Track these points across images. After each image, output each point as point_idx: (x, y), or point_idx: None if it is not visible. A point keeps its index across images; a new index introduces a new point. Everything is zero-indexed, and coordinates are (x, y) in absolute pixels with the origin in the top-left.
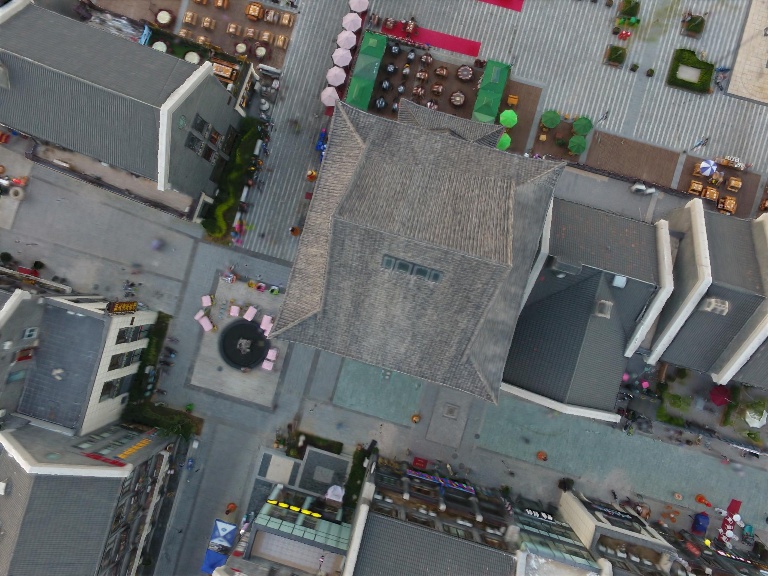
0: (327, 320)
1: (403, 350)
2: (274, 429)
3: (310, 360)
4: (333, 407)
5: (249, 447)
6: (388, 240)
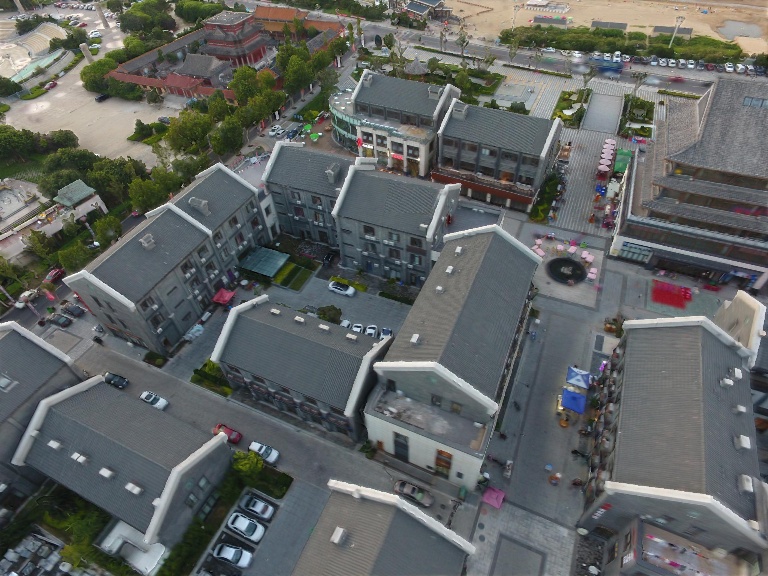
0: (702, 148)
1: (755, 161)
2: (601, 321)
3: (620, 283)
4: (648, 312)
5: (581, 331)
6: (749, 87)
